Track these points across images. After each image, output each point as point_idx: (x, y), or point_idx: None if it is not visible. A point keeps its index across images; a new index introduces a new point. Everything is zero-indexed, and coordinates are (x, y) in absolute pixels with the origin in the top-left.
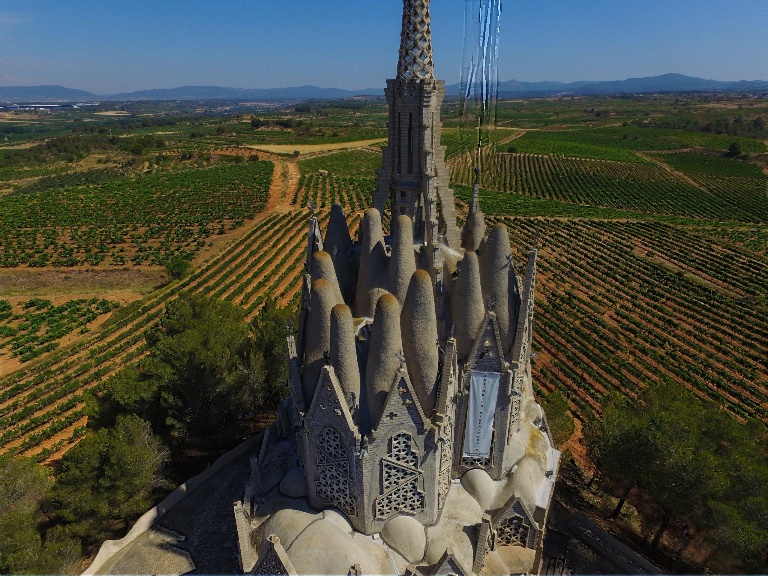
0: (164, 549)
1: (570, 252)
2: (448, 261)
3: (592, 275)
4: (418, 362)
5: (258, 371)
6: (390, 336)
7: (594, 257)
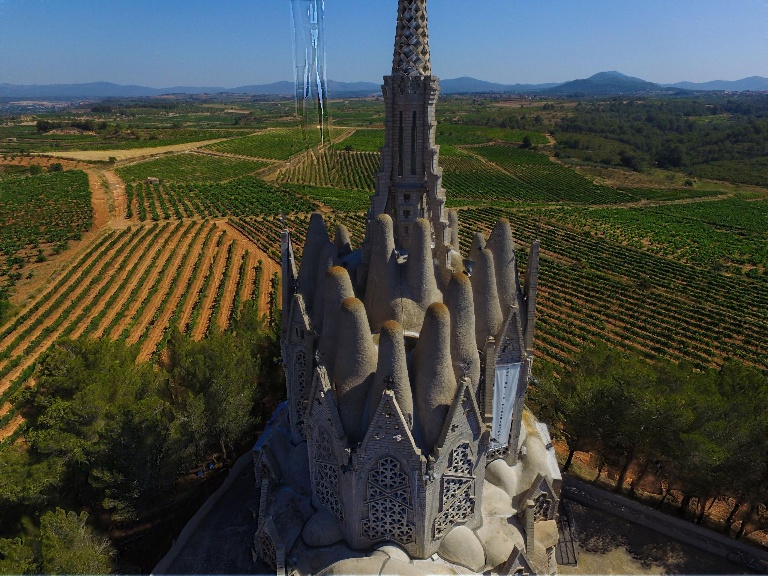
0: None
1: None
2: (454, 261)
3: None
4: None
5: (198, 416)
6: (446, 346)
7: None
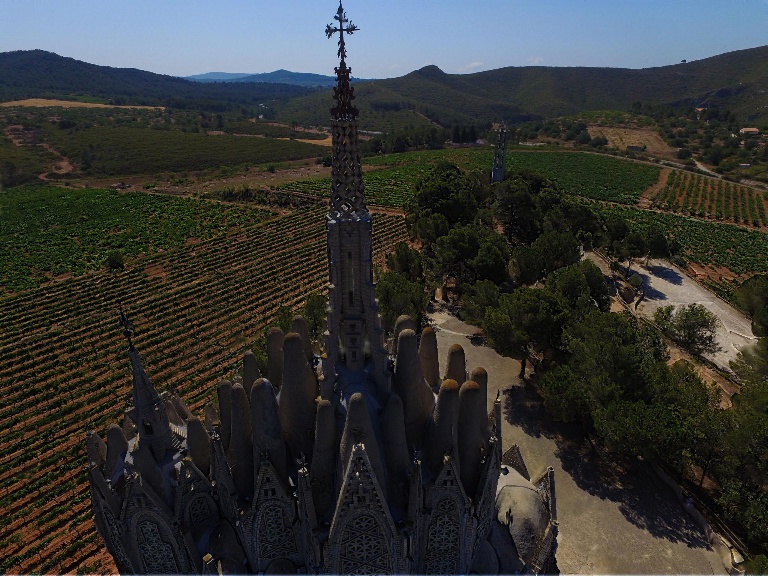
0: None
1: None
2: None
3: None
4: None
5: None
6: None
7: None
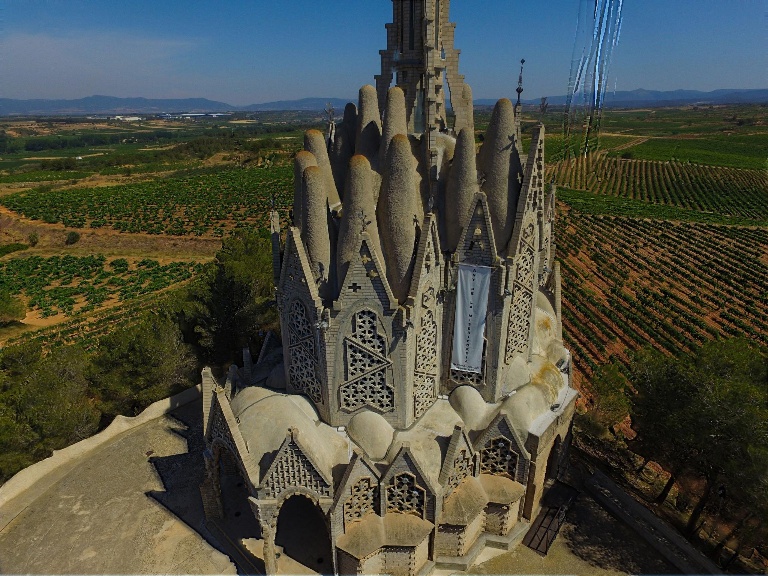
0: (167, 433)
1: (676, 253)
2: (448, 148)
3: (699, 277)
4: (392, 238)
5: None
6: (358, 199)
7: (706, 261)
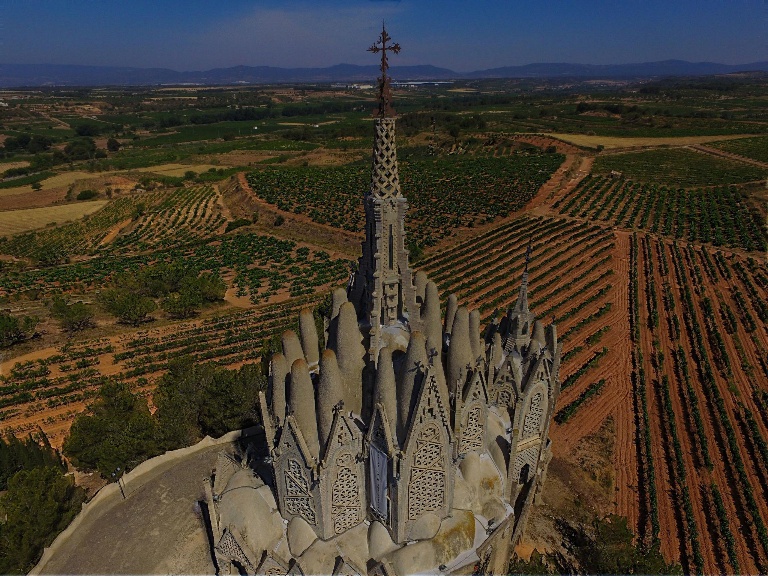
0: None
1: None
2: (389, 347)
3: None
4: (320, 416)
5: None
6: (295, 390)
7: None
